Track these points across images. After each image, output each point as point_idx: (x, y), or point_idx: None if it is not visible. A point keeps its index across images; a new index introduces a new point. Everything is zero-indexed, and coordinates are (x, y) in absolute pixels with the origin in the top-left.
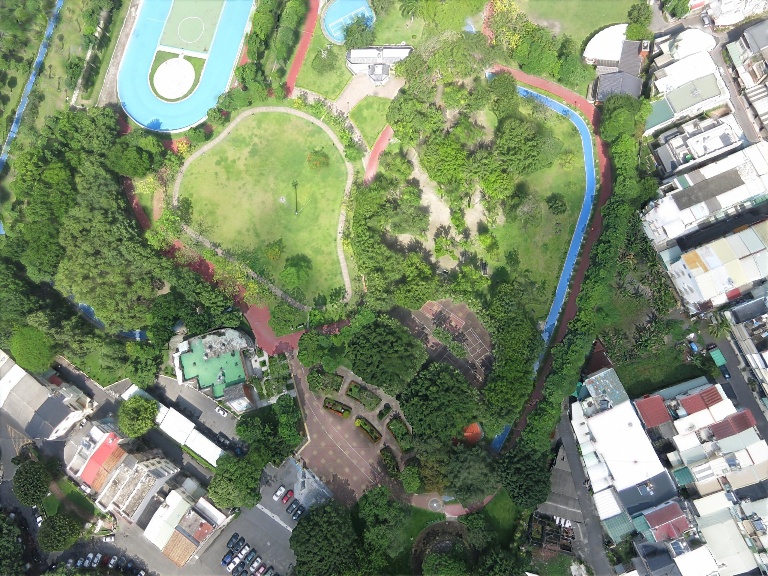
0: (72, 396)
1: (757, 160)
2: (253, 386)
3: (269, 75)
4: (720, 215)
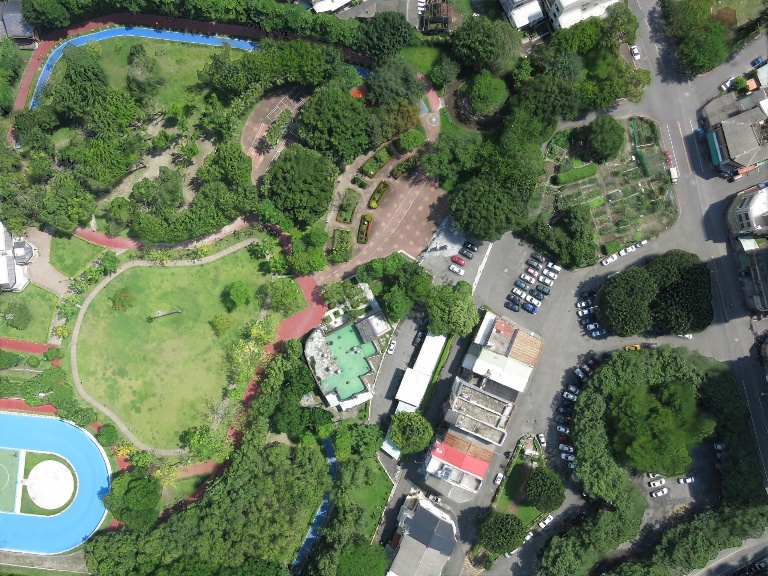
0: (406, 513)
1: None
2: (360, 319)
3: None
4: None
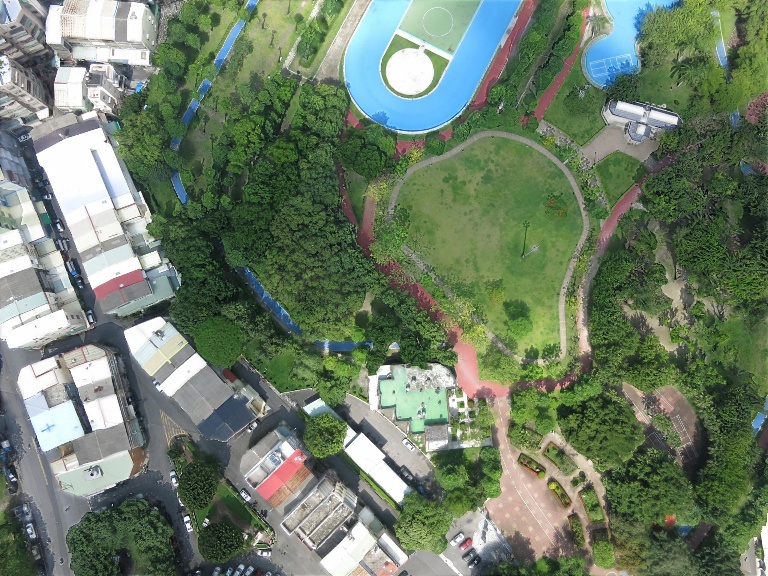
0: None
1: None
2: None
3: (518, 99)
4: None
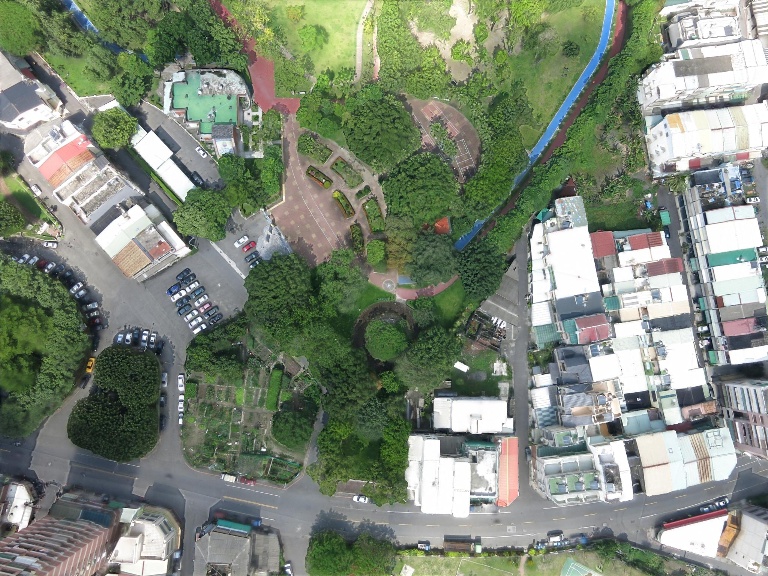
0: (45, 91)
1: (749, 53)
2: (240, 136)
3: None
4: (702, 100)
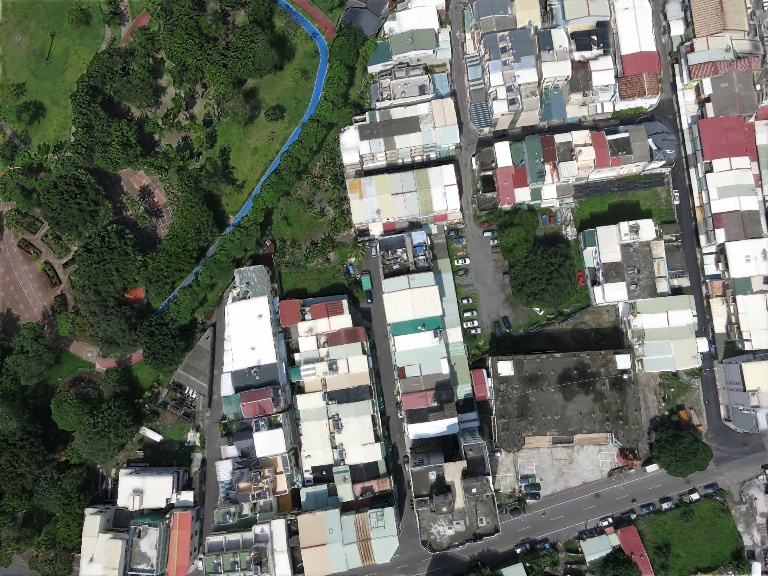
0: None
1: (437, 113)
2: None
3: None
4: (408, 160)
